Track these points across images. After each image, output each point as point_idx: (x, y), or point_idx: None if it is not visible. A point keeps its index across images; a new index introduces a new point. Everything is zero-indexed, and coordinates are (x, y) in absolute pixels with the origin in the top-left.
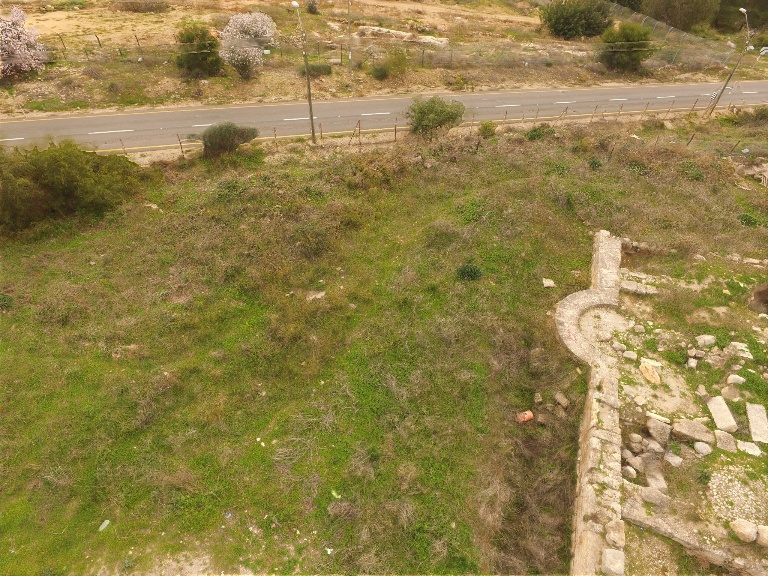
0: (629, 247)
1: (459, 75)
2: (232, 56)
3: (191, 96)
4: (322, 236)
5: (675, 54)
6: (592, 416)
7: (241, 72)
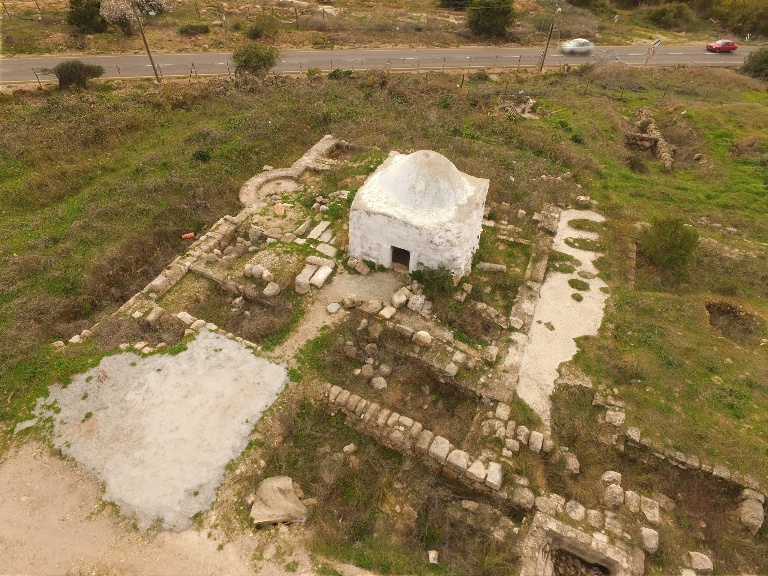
0: (343, 146)
1: (328, 36)
2: (109, 14)
3: (76, 48)
4: (101, 132)
5: (543, 22)
6: (213, 226)
7: (123, 29)
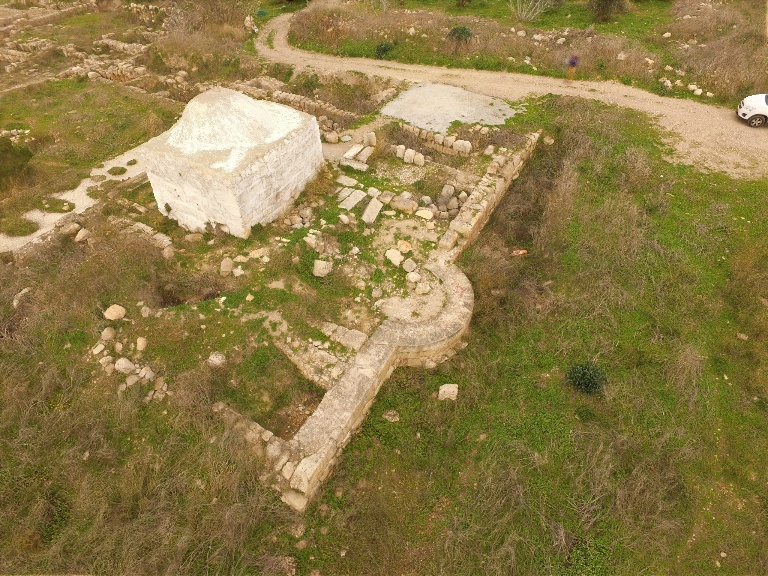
0: None
1: None
2: None
3: None
4: None
5: None
6: None
7: None
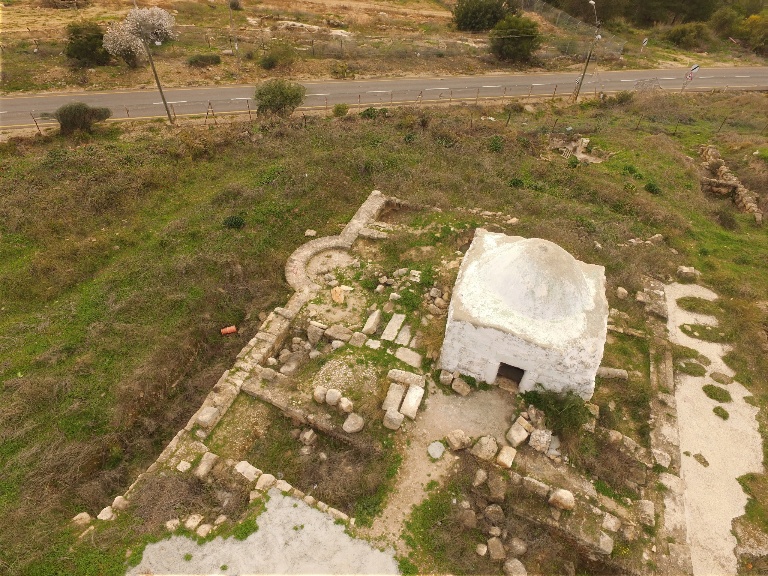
0: (394, 204)
1: (347, 65)
2: (113, 46)
3: (76, 83)
4: (115, 194)
5: (567, 45)
6: None
7: (128, 61)
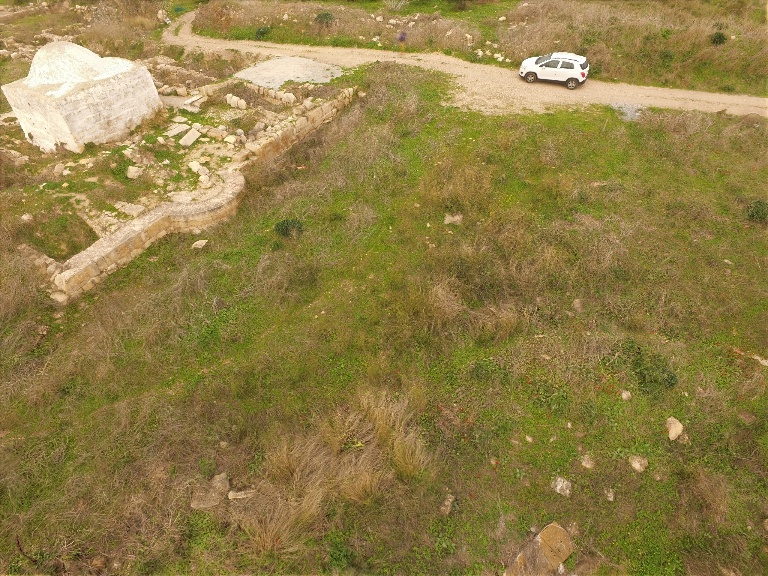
0: None
1: None
2: None
3: None
4: None
5: None
6: None
7: None
